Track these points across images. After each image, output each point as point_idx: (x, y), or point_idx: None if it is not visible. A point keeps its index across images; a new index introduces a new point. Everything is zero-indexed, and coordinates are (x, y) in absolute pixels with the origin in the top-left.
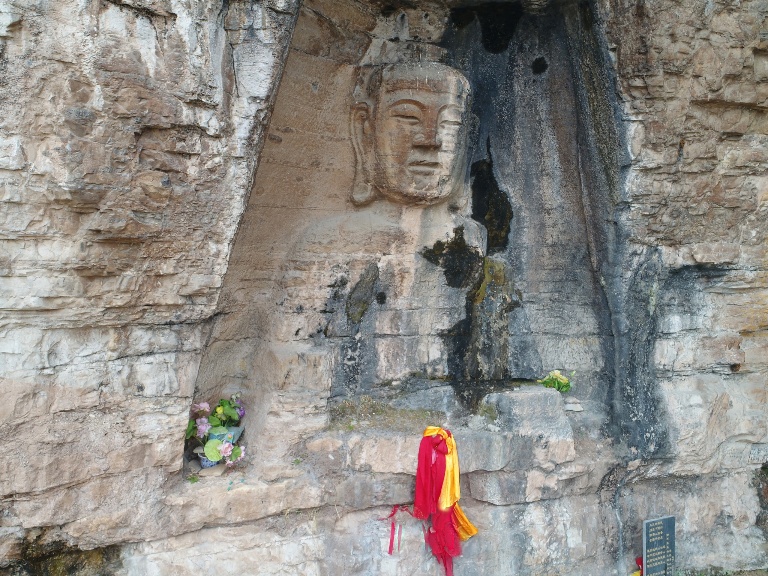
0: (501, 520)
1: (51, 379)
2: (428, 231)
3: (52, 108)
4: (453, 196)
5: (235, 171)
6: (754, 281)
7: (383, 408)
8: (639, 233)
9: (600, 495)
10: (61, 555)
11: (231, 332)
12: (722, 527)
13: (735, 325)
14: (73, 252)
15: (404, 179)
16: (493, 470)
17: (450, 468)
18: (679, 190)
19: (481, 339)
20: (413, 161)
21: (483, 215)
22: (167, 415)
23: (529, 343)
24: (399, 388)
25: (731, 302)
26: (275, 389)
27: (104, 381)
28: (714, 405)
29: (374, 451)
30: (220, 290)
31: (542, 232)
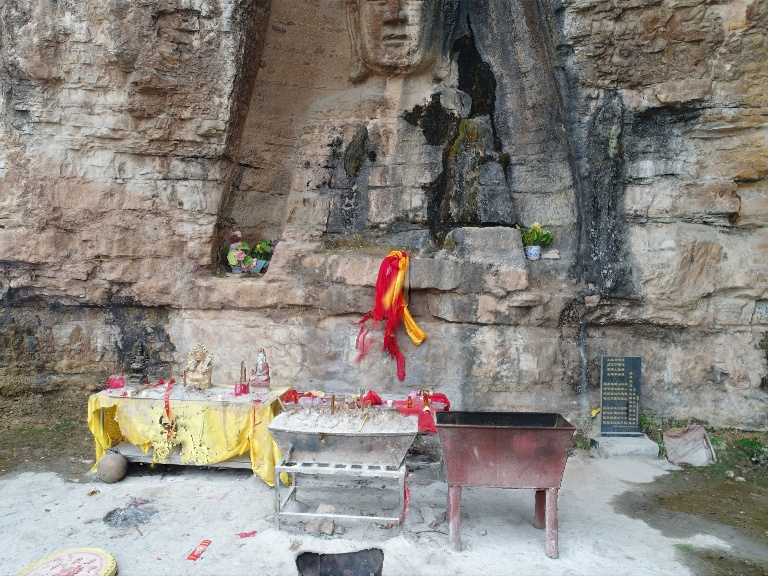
0: (452, 334)
1: (122, 187)
2: (407, 97)
3: (103, 3)
4: (433, 68)
5: (226, 43)
6: (738, 120)
7: (370, 244)
8: (588, 75)
9: (561, 330)
10: (133, 308)
11: (264, 185)
12: (713, 383)
13: (727, 172)
14: (125, 99)
15: (379, 52)
16: (444, 289)
17: (401, 280)
18: (624, 28)
19: (454, 188)
20: (384, 36)
21: (471, 86)
22: (199, 225)
23: (498, 191)
24: (386, 230)
25: (720, 147)
26: (286, 223)
27: (155, 194)
28: (693, 251)
29: (348, 267)
30: (226, 133)
31: (523, 96)
